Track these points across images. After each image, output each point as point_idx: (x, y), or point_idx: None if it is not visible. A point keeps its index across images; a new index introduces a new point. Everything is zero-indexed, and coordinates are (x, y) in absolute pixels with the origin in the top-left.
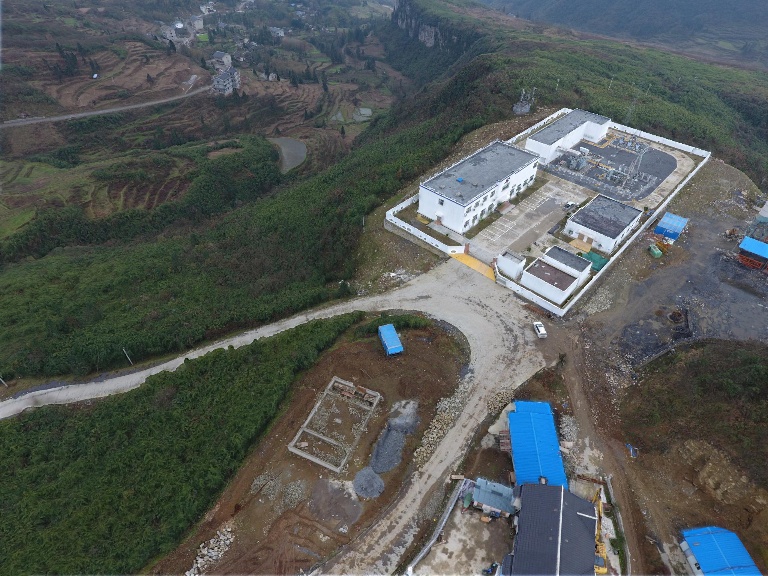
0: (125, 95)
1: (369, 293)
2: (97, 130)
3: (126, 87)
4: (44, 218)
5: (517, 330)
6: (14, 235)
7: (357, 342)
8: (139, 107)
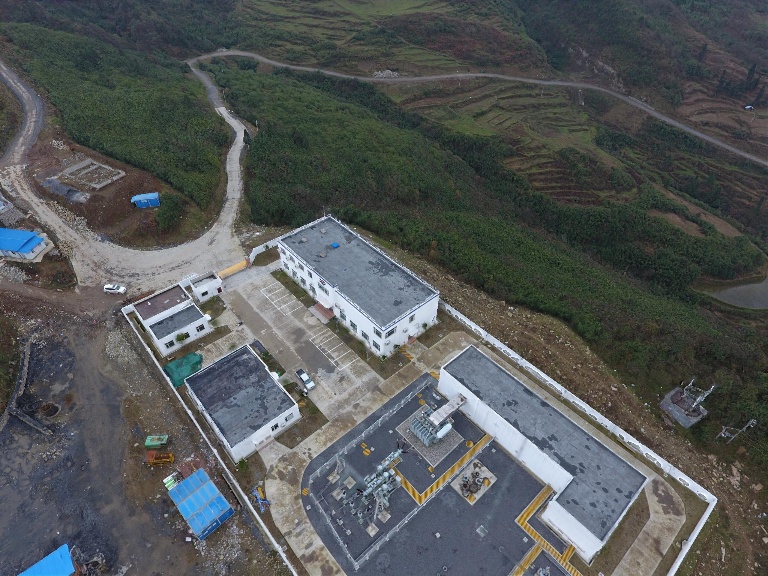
0: (739, 135)
1: (245, 224)
2: (667, 141)
3: (753, 130)
4: (487, 140)
5: (129, 279)
6: (462, 134)
7: (160, 191)
8: (732, 151)
